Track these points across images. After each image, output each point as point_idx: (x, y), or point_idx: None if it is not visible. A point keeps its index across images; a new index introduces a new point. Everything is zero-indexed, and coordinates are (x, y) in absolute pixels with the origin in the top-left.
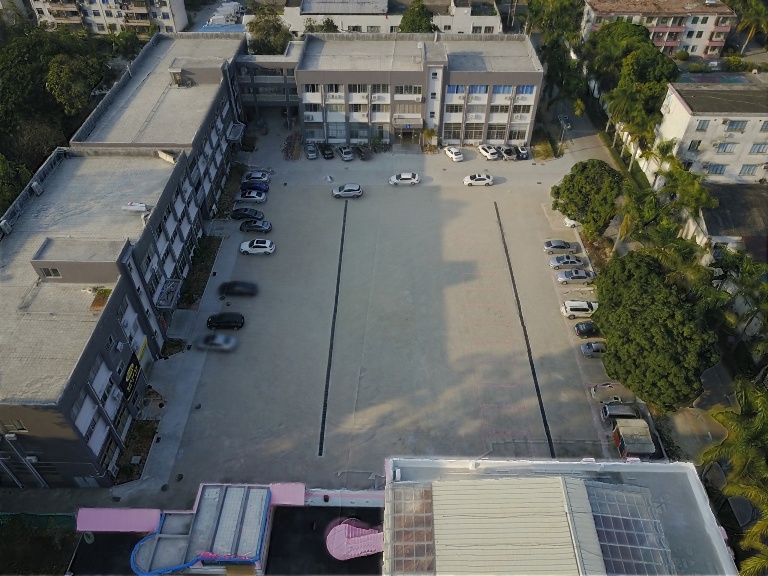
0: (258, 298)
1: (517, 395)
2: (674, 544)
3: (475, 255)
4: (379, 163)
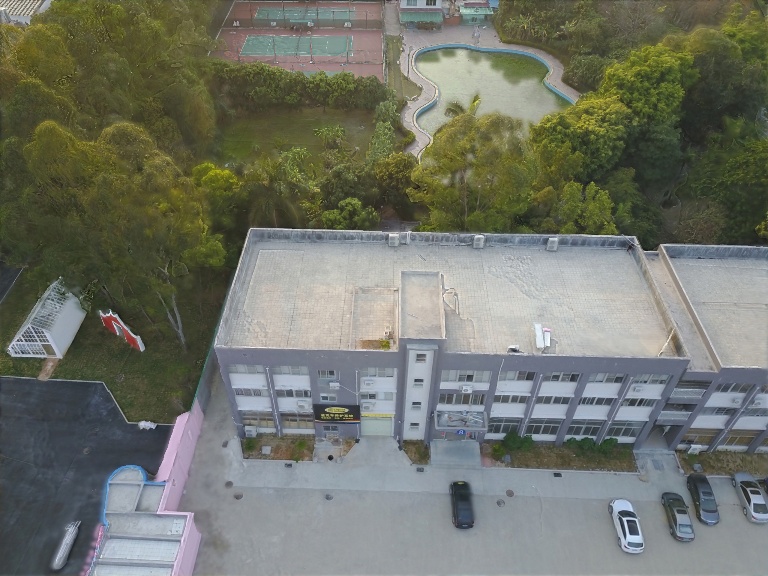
0: (520, 542)
1: None
2: None
3: None
4: None
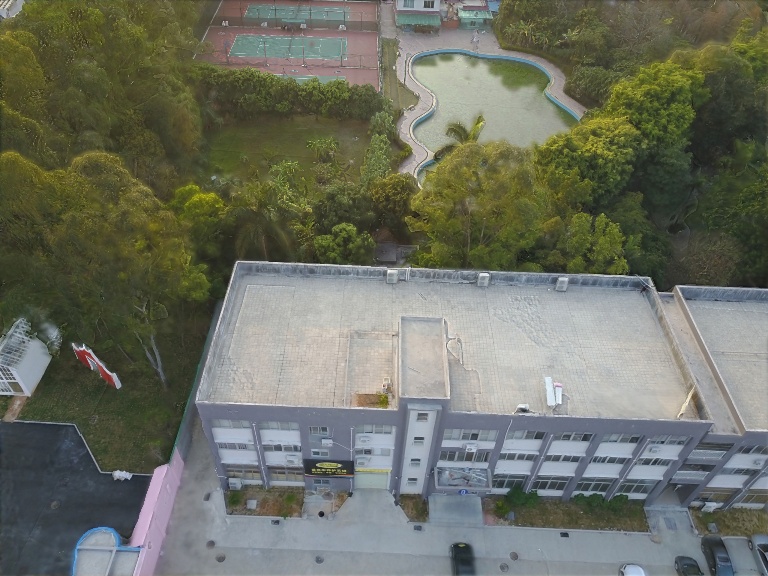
0: None
1: None
2: None
3: None
4: None
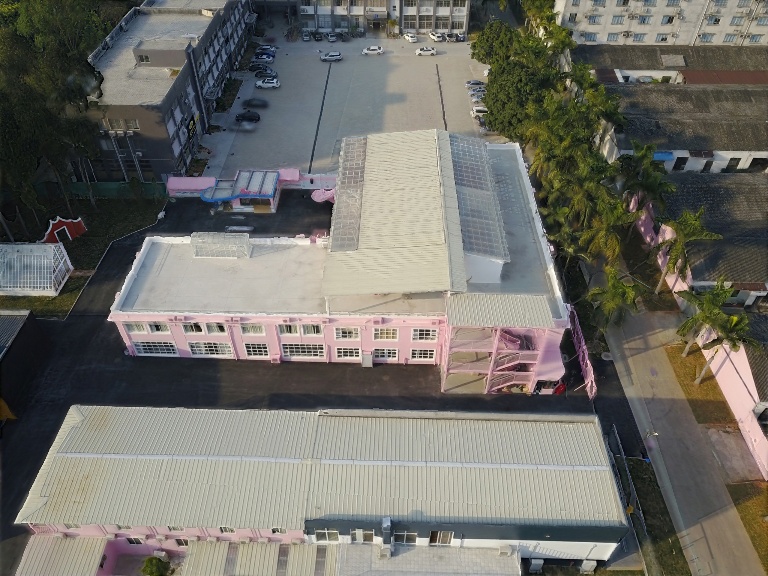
0: (269, 109)
1: None
2: (499, 172)
3: (418, 90)
4: (355, 43)
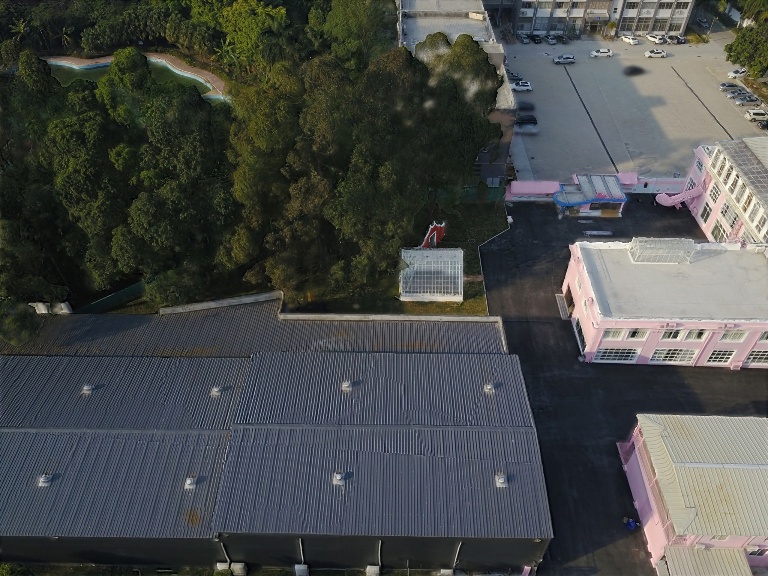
0: (536, 112)
1: None
2: None
3: (672, 93)
4: (576, 46)
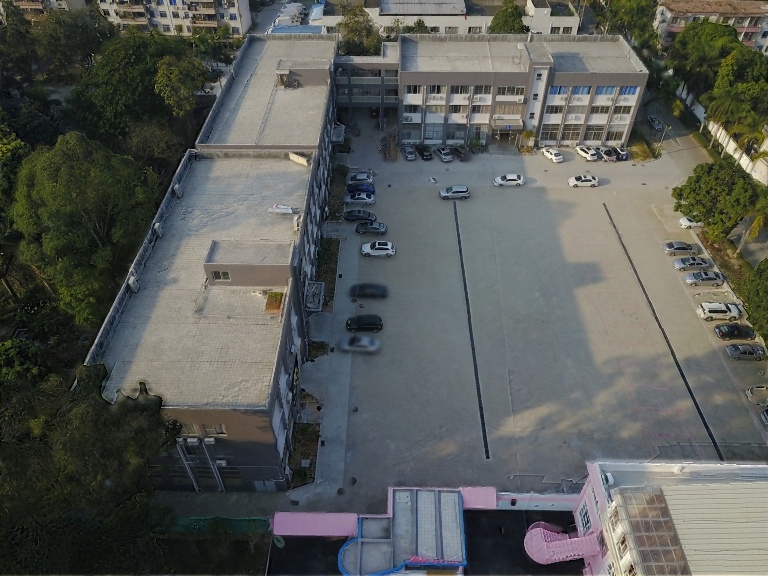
0: (389, 300)
1: (671, 398)
2: None
3: (596, 257)
4: (479, 164)
